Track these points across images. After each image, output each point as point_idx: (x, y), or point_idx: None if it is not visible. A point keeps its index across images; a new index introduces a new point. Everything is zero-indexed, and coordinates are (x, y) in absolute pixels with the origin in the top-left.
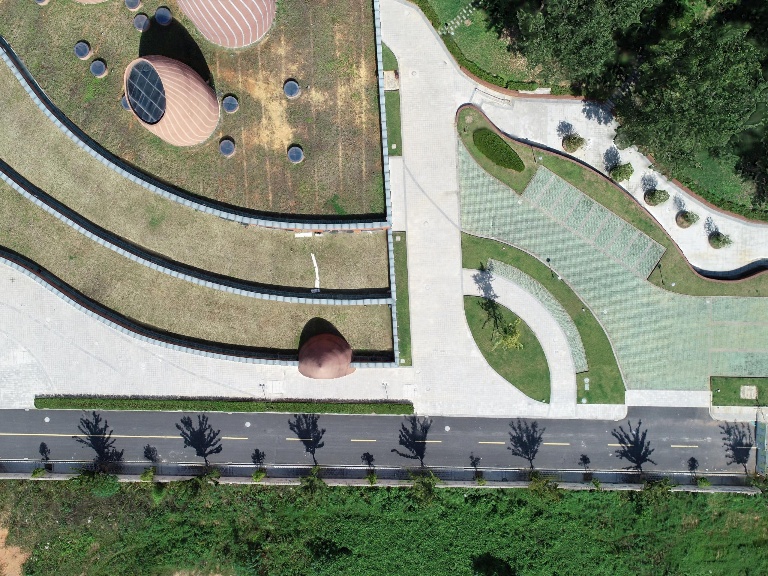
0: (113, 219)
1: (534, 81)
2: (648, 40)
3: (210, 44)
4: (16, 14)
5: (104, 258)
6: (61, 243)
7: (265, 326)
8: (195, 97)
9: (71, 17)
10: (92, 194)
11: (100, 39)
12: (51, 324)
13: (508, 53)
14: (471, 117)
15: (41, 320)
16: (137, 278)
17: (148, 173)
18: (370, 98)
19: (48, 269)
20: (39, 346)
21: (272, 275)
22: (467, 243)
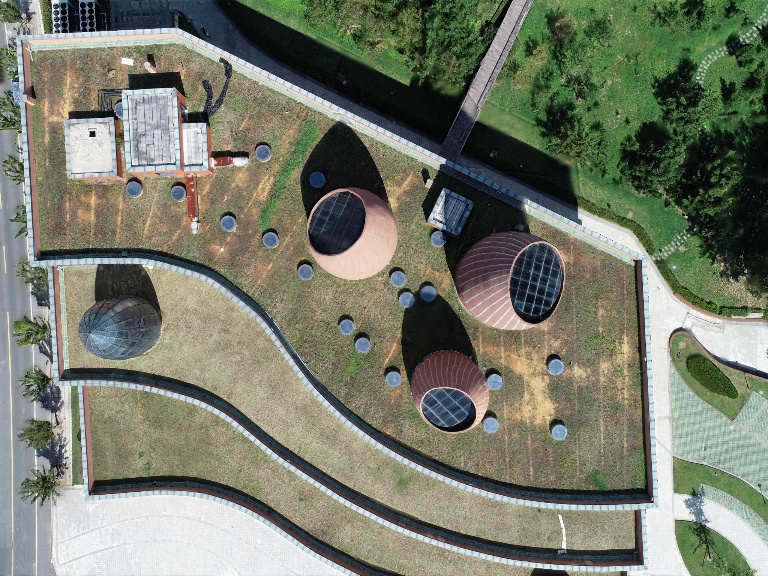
0: (361, 479)
1: (746, 306)
2: None
3: (473, 319)
4: (279, 288)
5: (334, 500)
6: (291, 485)
7: (494, 569)
8: None
9: (334, 292)
10: (340, 454)
11: (363, 314)
12: (262, 546)
13: (721, 279)
14: (684, 343)
15: (252, 542)
16: (367, 520)
17: (409, 447)
18: (632, 374)
19: (278, 511)
20: (249, 568)
21: (519, 536)
22: (679, 469)
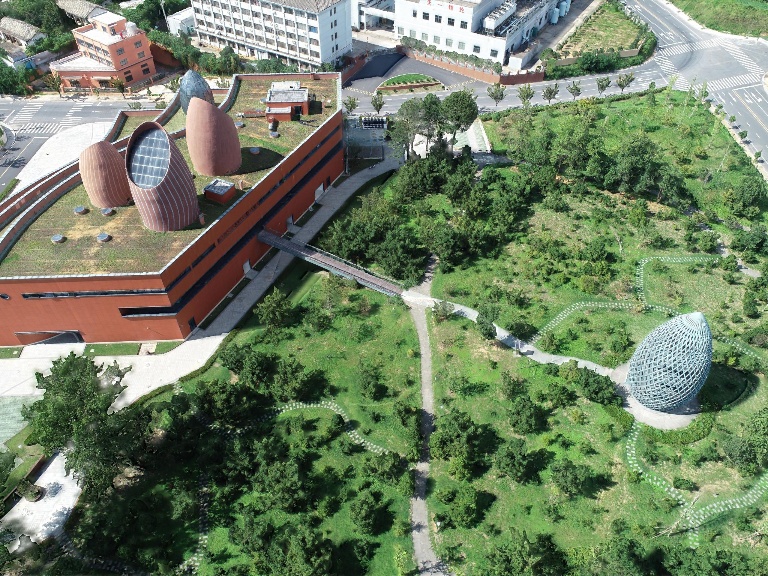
0: None
1: None
2: (94, 551)
3: None
4: None
5: None
6: None
7: None
8: (91, 175)
9: None
10: None
11: None
12: None
13: None
14: None
15: None
16: None
17: None
18: None
19: None
20: None
21: None
22: None
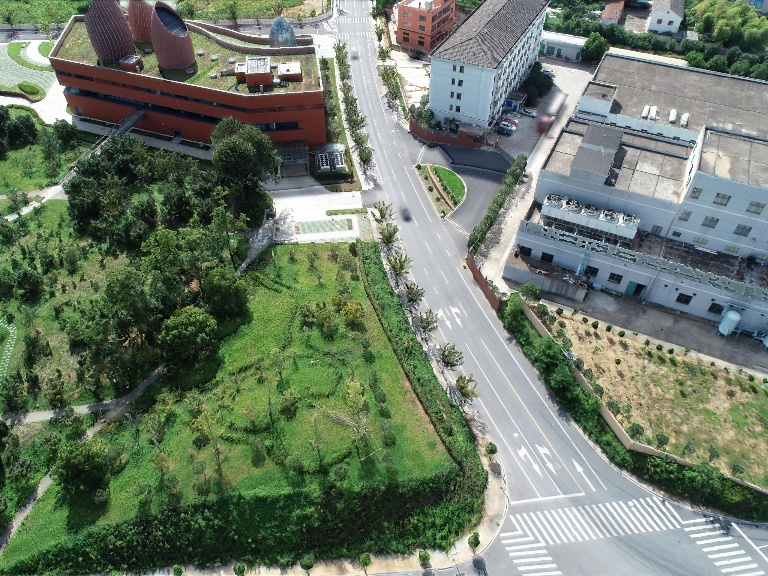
0: None
1: None
2: None
3: None
4: None
5: None
6: None
7: None
8: None
9: None
10: None
11: None
12: None
13: None
14: None
15: None
16: None
17: None
18: None
19: None
20: None
21: None
22: None
